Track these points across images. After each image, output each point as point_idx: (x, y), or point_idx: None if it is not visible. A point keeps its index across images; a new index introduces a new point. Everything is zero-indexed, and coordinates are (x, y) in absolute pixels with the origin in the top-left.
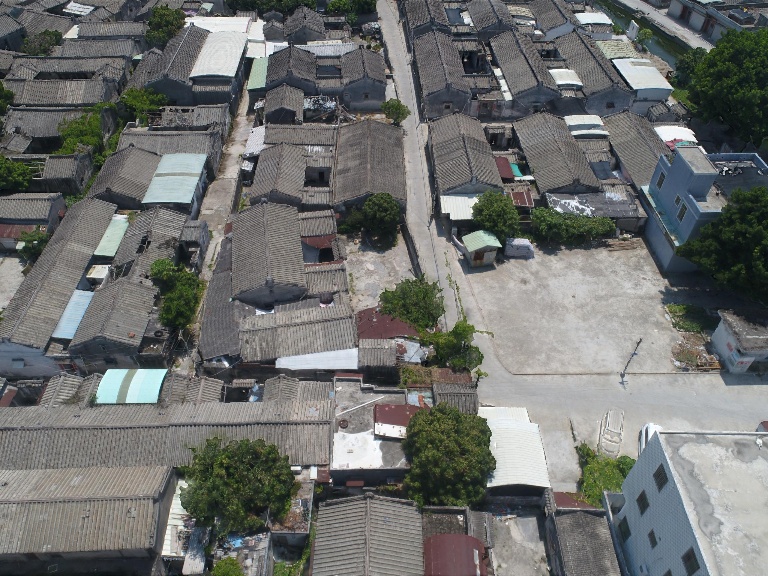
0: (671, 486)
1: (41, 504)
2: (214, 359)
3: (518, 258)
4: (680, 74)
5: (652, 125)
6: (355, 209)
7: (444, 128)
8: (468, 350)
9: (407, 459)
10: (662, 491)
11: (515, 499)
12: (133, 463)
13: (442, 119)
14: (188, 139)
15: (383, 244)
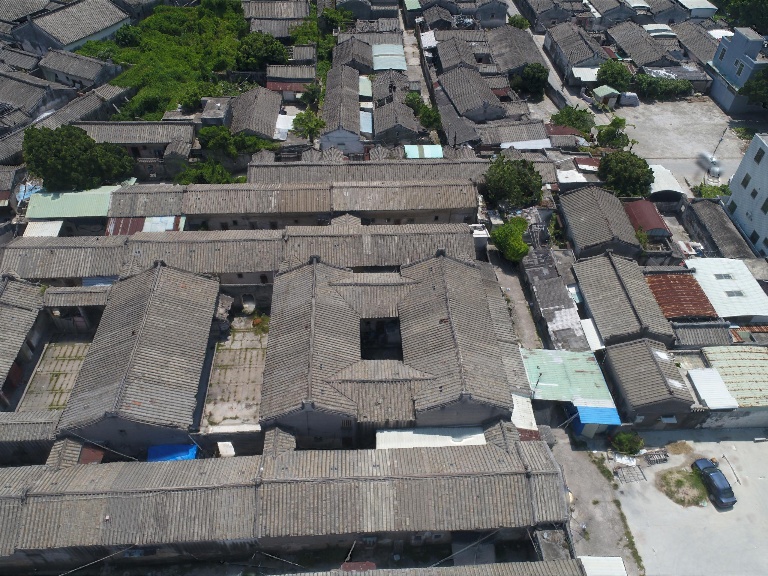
0: (767, 154)
1: (412, 188)
2: (462, 144)
3: (628, 106)
4: (716, 5)
5: (706, 30)
6: (517, 75)
7: (561, 31)
8: (621, 135)
9: (601, 180)
10: (761, 162)
11: (663, 205)
12: None
13: (557, 26)
14: (386, 36)
15: (535, 99)
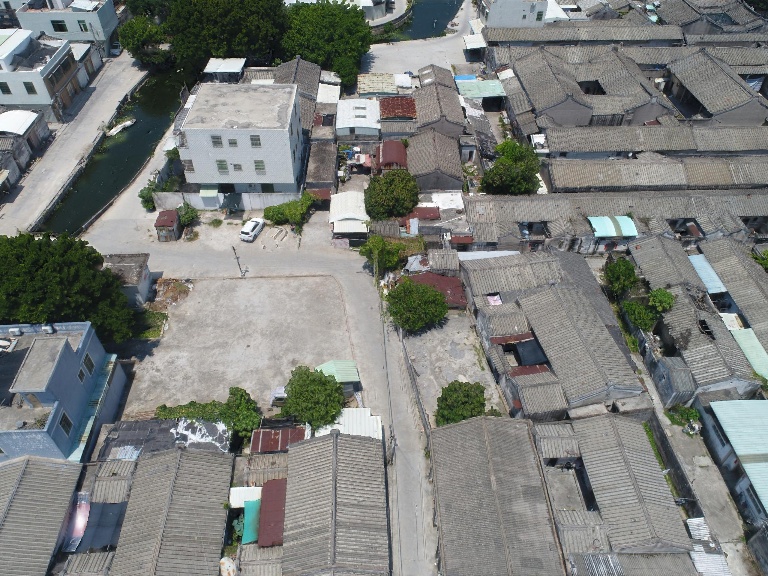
0: None
1: None
2: None
3: None
4: None
5: None
6: None
7: None
8: None
9: None
10: None
11: None
12: (579, 193)
13: None
14: None
15: None
